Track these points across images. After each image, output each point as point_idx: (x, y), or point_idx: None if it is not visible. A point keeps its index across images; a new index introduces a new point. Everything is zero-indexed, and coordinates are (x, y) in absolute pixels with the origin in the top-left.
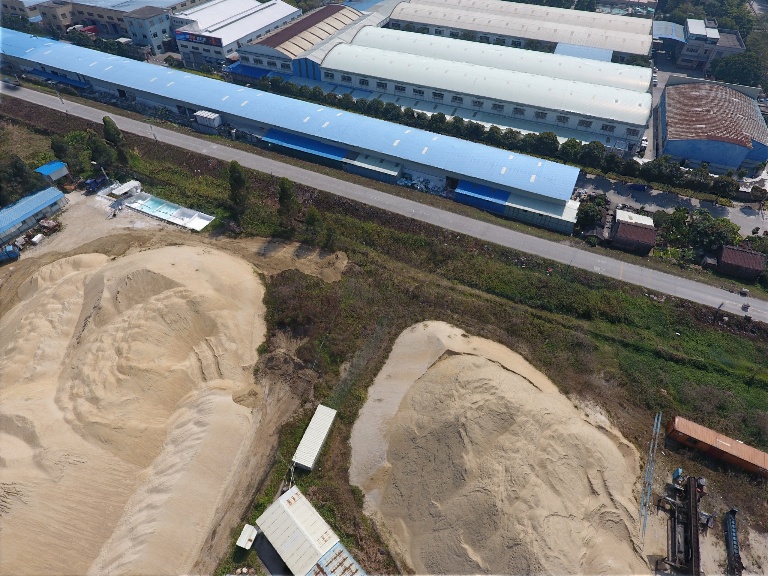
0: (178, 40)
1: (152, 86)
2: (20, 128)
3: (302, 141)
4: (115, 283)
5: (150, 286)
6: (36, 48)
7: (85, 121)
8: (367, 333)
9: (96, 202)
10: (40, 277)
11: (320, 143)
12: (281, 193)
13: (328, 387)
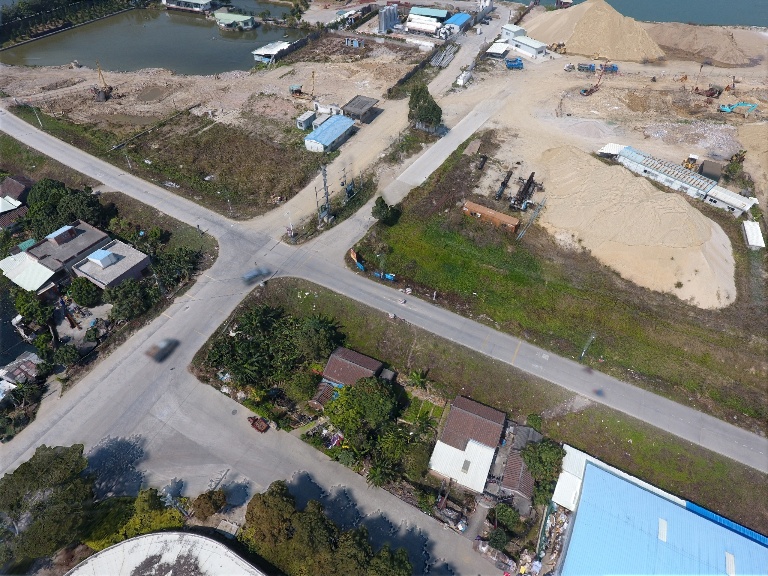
0: None
1: None
2: None
3: None
4: None
5: None
6: None
7: None
8: (767, 298)
9: None
10: None
11: None
12: None
13: (767, 263)
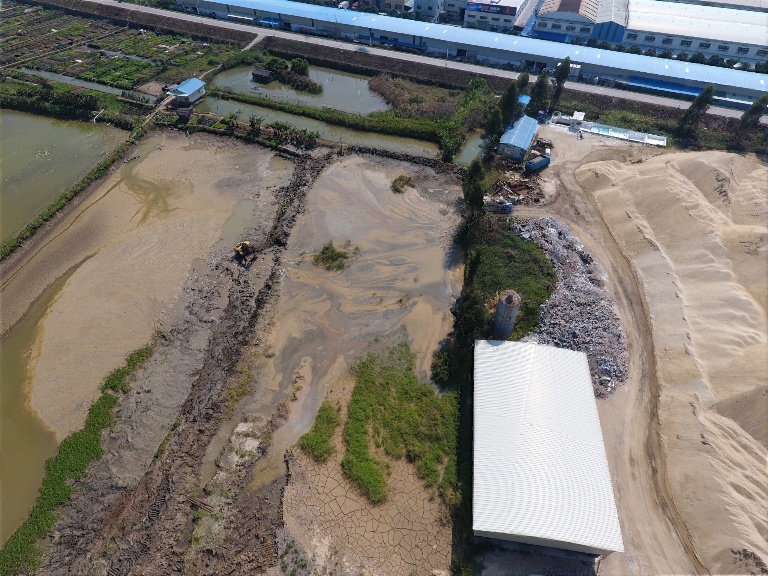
0: (467, 11)
1: (501, 44)
2: (404, 80)
3: (666, 84)
4: (722, 164)
5: (744, 167)
6: (359, 17)
7: (466, 72)
8: None
9: (554, 128)
10: (604, 173)
11: (684, 86)
12: (756, 109)
13: None
